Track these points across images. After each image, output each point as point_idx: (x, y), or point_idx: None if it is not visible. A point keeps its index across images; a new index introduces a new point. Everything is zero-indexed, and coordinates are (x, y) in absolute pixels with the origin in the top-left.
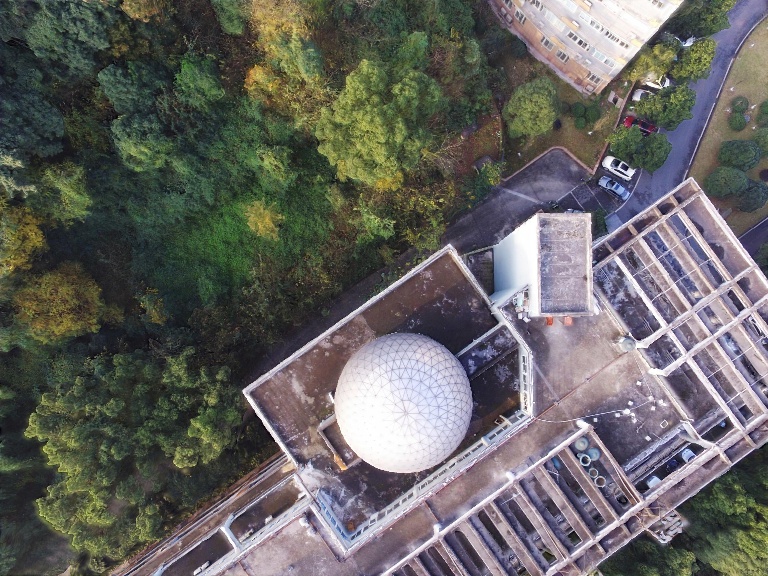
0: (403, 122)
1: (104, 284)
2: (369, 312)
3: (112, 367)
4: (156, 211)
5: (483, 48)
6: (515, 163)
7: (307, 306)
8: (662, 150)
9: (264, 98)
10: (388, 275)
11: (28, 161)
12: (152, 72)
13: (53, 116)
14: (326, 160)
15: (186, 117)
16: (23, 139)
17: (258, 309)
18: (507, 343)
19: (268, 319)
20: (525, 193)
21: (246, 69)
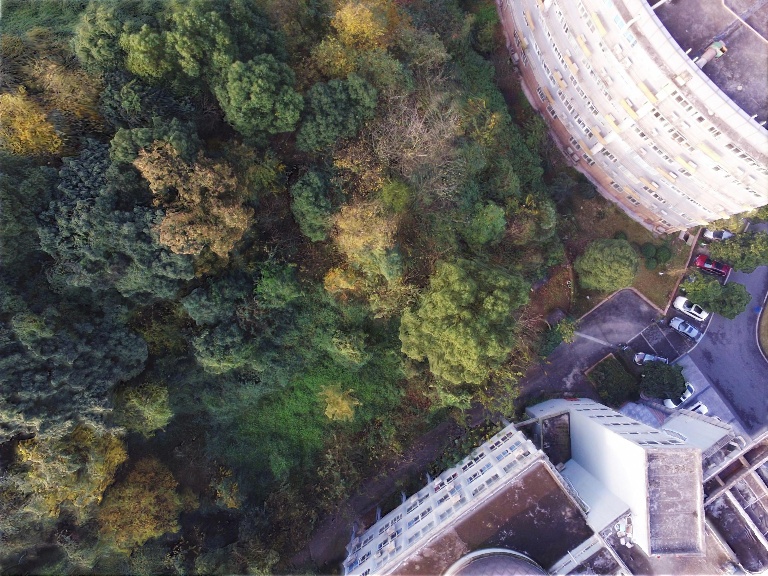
0: (496, 338)
1: (181, 478)
2: (460, 523)
3: (193, 566)
4: (231, 400)
5: (551, 194)
6: (583, 306)
7: (381, 480)
8: (742, 304)
9: (343, 293)
10: (462, 441)
11: (115, 396)
12: (233, 284)
13: (139, 348)
14: (398, 330)
15: (265, 318)
16: (113, 383)
17: (334, 491)
18: (607, 564)
19: (344, 498)
20: (594, 335)
21: (325, 268)
